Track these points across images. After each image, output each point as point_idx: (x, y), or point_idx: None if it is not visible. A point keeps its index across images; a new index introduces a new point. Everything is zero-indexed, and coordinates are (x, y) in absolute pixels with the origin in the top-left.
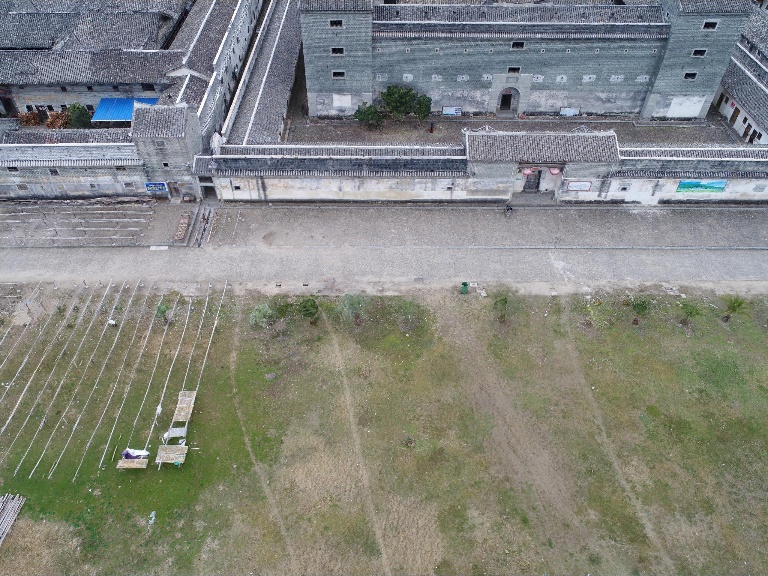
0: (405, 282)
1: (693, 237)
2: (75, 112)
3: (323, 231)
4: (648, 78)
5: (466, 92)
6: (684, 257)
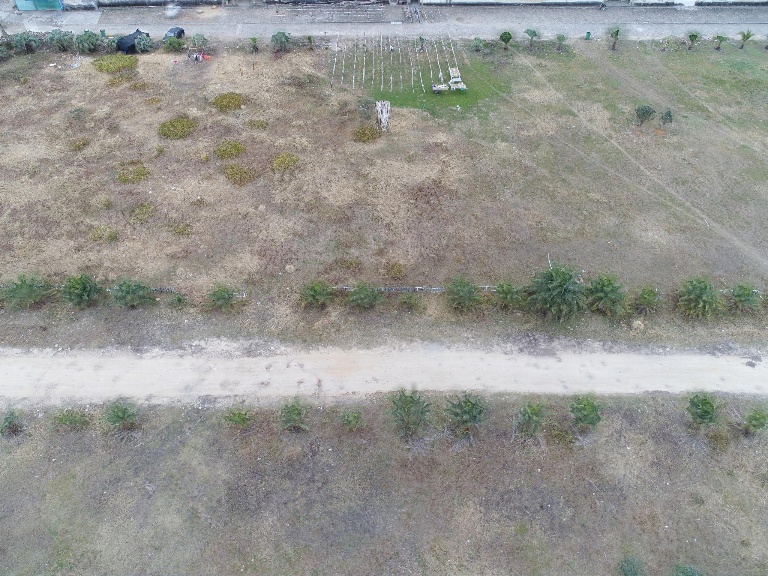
0: (551, 35)
1: (718, 19)
2: None
3: (492, 17)
4: None
5: None
6: (714, 26)
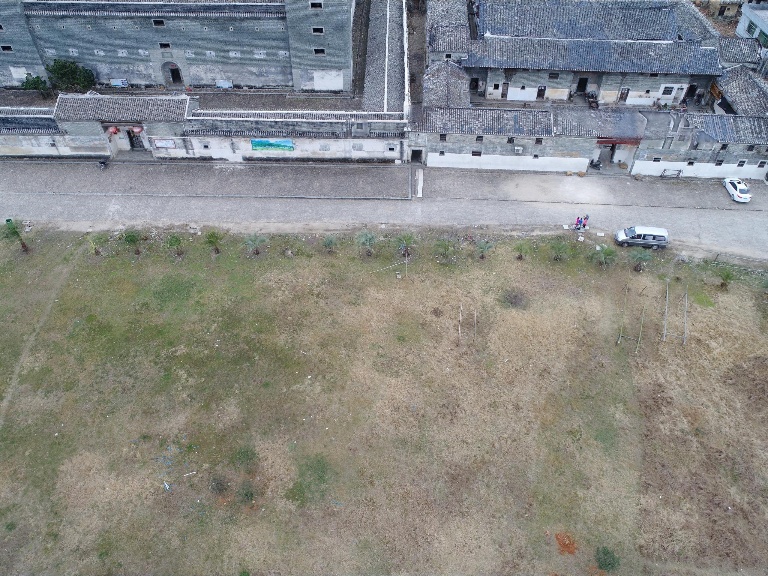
0: None
1: (250, 188)
2: None
3: None
4: (288, 54)
5: (131, 66)
6: (228, 203)
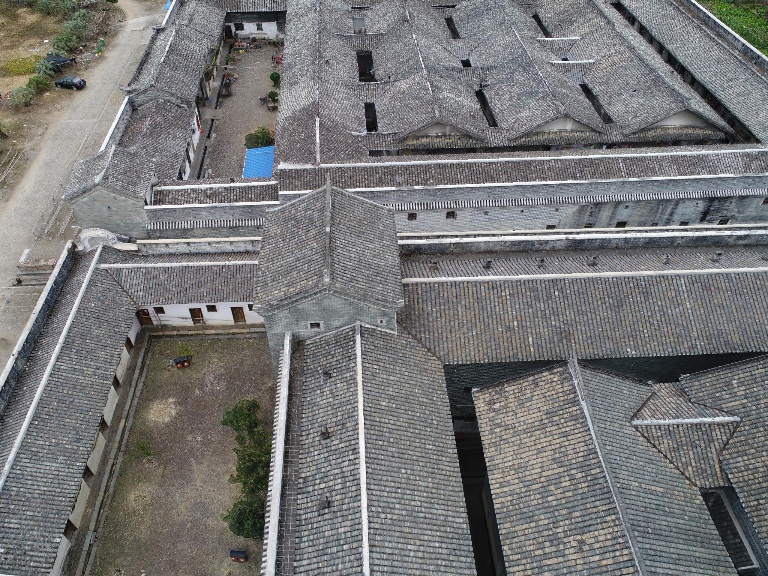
0: None
1: None
2: (251, 134)
3: None
4: None
5: None
6: None
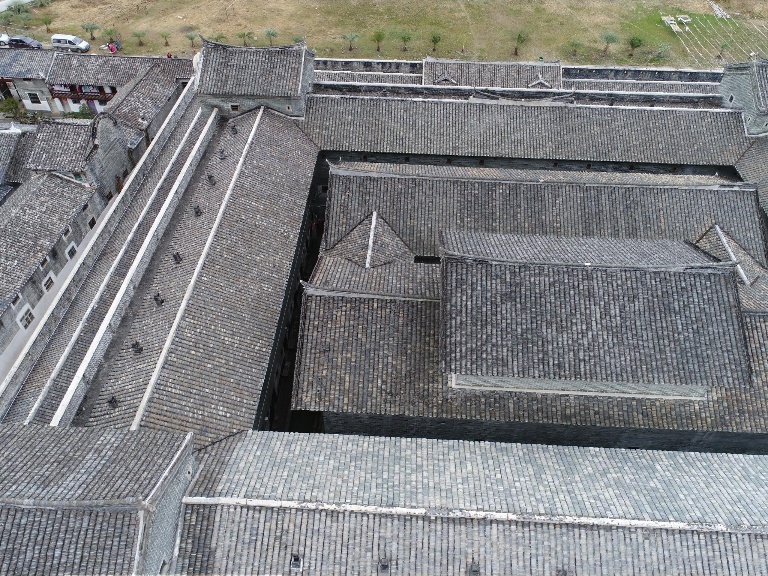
0: None
1: None
2: None
3: None
4: None
5: None
6: None
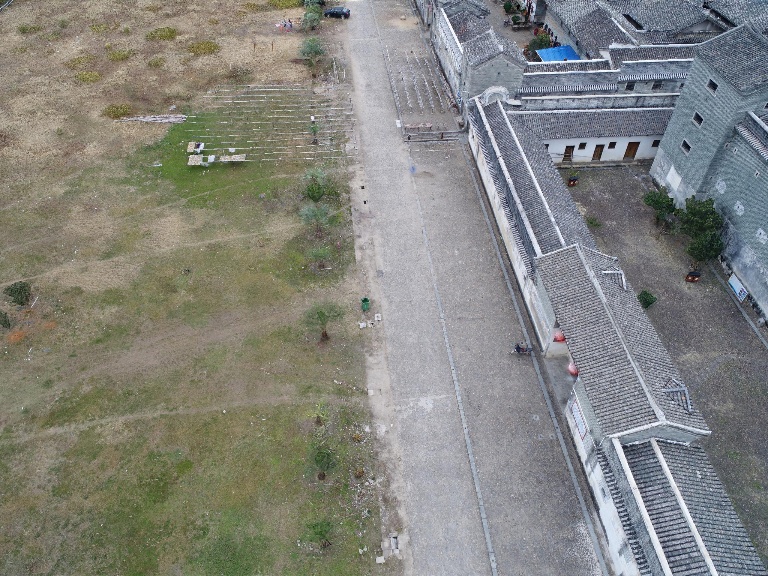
0: (375, 263)
1: None
2: (536, 38)
3: (443, 205)
4: None
5: None
6: None
